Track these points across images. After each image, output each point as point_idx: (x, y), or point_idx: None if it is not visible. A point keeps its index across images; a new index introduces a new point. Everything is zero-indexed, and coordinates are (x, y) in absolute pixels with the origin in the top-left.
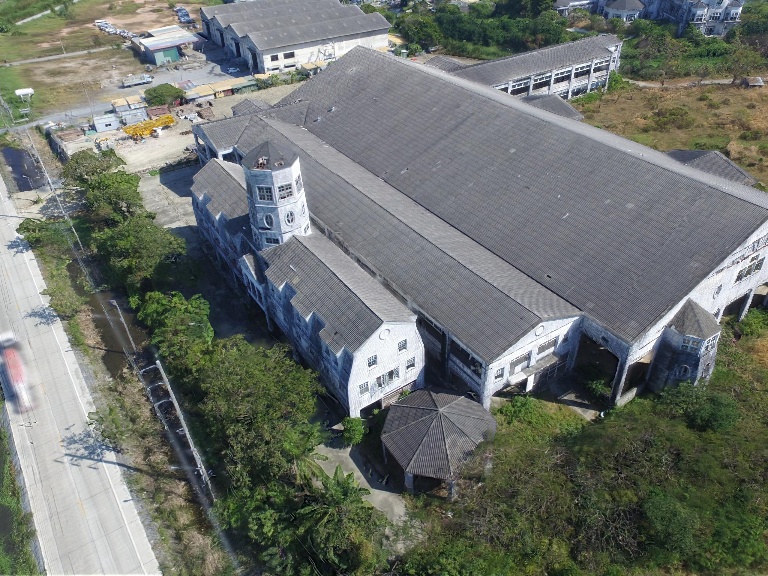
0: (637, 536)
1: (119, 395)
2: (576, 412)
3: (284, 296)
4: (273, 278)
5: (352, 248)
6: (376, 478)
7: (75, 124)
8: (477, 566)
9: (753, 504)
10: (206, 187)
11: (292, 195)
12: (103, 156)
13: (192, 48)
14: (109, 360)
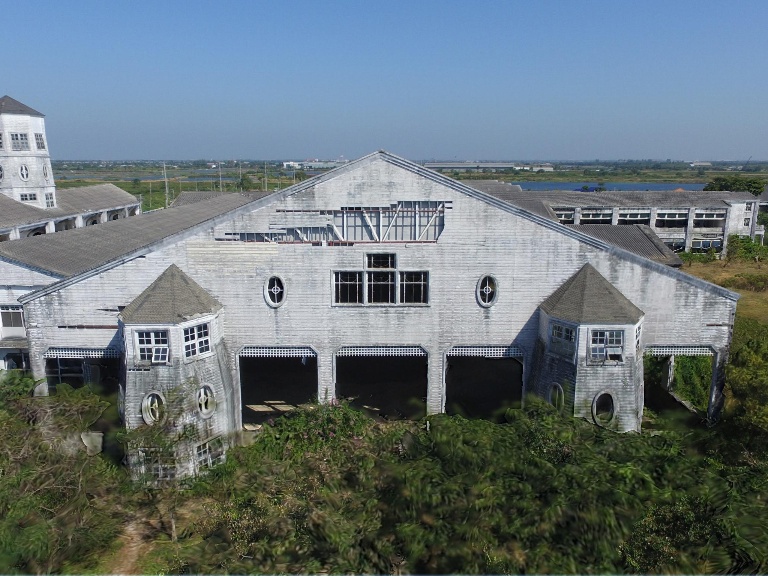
0: None
1: None
2: None
3: None
4: None
5: None
6: None
7: None
8: None
9: None
10: None
11: (3, 147)
12: None
13: None
14: None
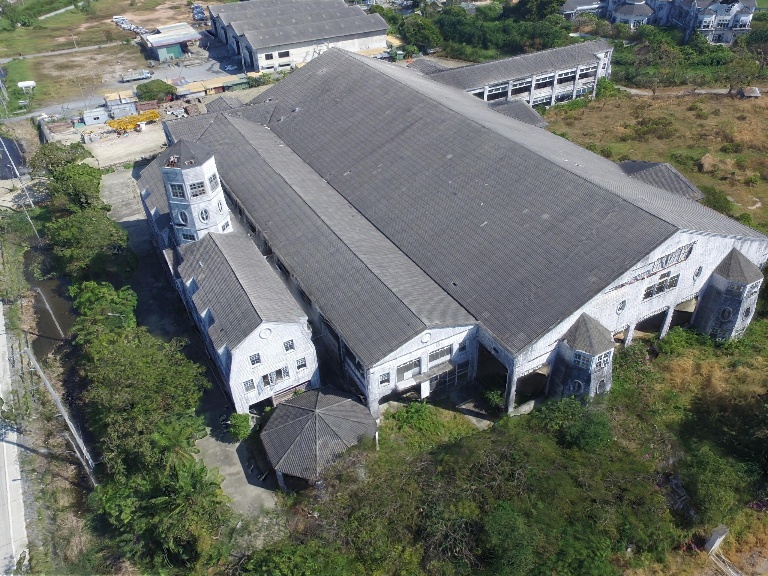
0: (474, 549)
1: (38, 379)
2: (470, 421)
3: (193, 291)
4: (183, 273)
5: (274, 247)
6: (255, 474)
7: (67, 116)
8: (311, 566)
9: (599, 525)
10: (149, 182)
11: (205, 193)
12: (70, 149)
13: (198, 45)
14: (38, 345)
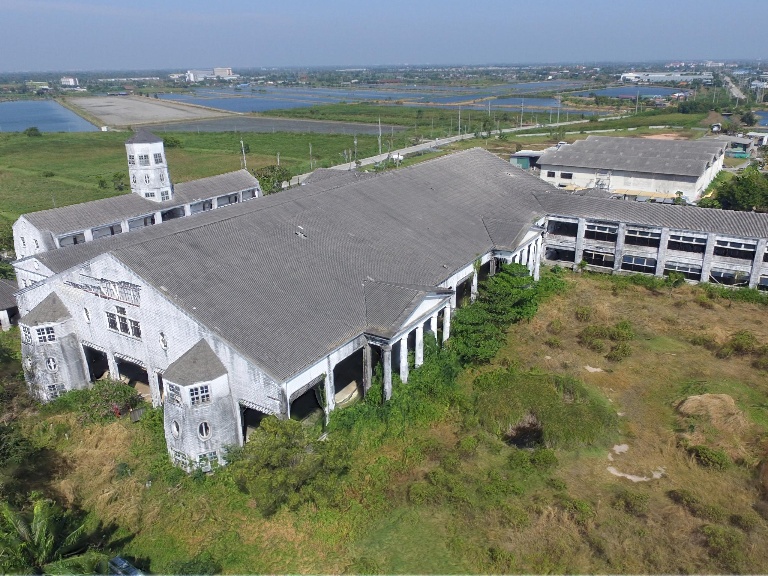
0: None
1: None
2: None
3: None
4: None
5: None
6: None
7: None
8: None
9: None
10: None
11: (135, 164)
12: None
13: None
14: None
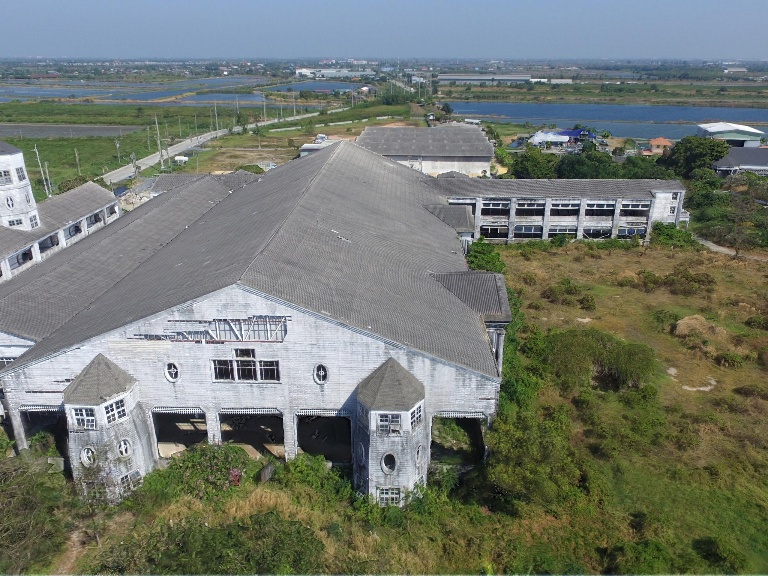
0: None
1: None
2: None
3: None
4: None
5: None
6: None
7: None
8: None
9: None
10: None
11: None
12: None
13: None
14: None
